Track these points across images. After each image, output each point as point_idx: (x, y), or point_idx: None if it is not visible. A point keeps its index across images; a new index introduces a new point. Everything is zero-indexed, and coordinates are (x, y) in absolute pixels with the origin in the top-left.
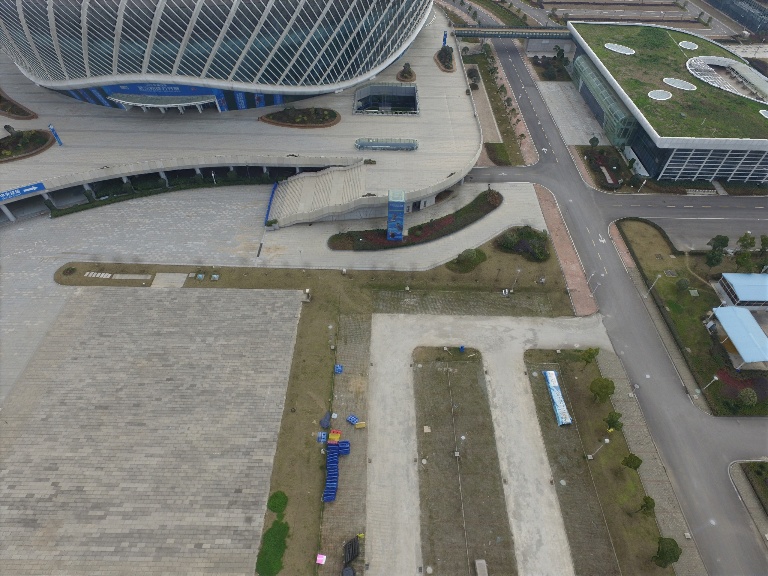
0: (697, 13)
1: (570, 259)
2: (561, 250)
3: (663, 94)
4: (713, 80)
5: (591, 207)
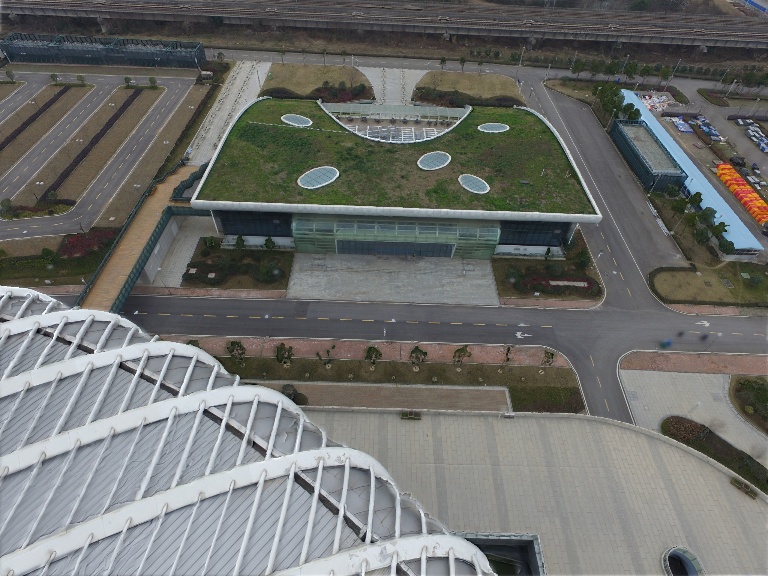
0: (133, 82)
1: (765, 364)
2: (754, 369)
3: (471, 181)
4: (413, 135)
5: (644, 317)
